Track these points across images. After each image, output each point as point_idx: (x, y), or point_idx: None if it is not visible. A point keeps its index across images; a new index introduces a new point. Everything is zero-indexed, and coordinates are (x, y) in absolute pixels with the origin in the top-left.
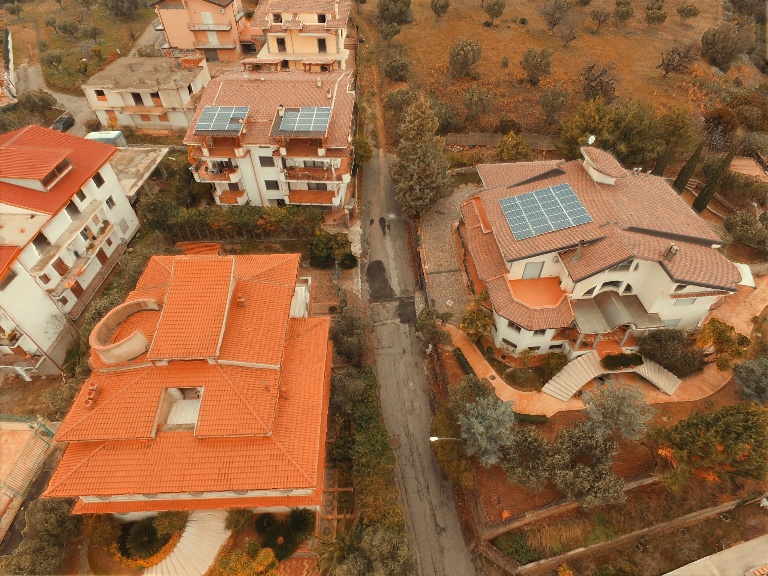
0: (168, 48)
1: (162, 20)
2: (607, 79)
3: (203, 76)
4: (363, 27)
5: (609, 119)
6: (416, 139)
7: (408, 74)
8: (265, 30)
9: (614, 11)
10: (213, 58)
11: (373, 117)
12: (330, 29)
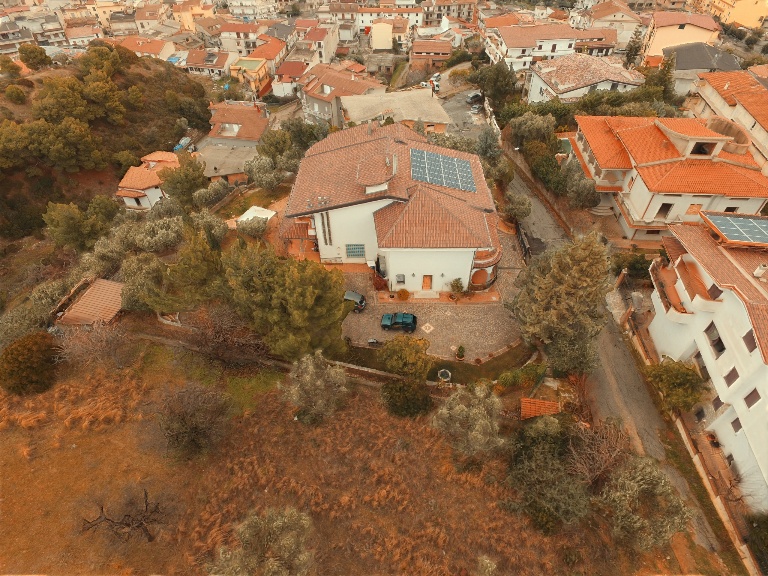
0: None
1: None
2: None
3: None
4: None
5: None
6: None
7: None
8: None
9: None
10: None
11: None
12: None
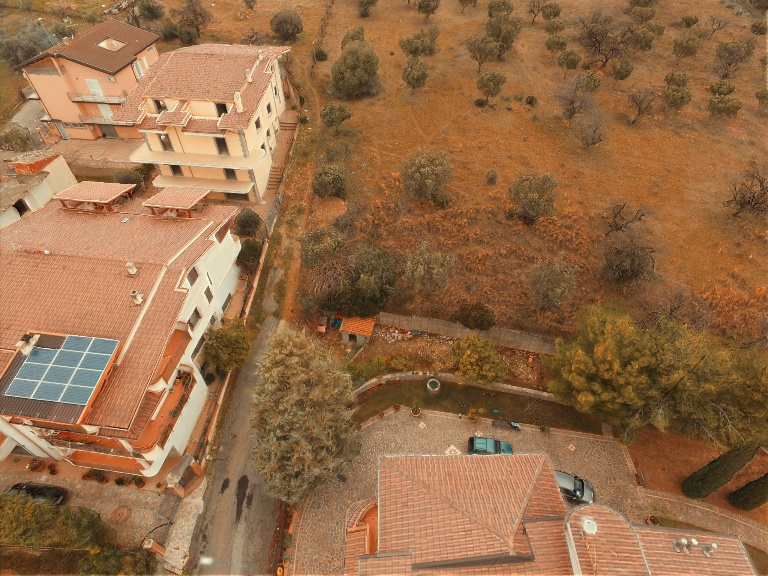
0: (49, 121)
1: (34, 87)
2: (644, 216)
3: (56, 181)
4: (312, 98)
5: (639, 365)
6: (281, 390)
7: (350, 185)
8: (136, 125)
9: (662, 94)
10: (112, 133)
11: (287, 255)
12: (226, 129)
